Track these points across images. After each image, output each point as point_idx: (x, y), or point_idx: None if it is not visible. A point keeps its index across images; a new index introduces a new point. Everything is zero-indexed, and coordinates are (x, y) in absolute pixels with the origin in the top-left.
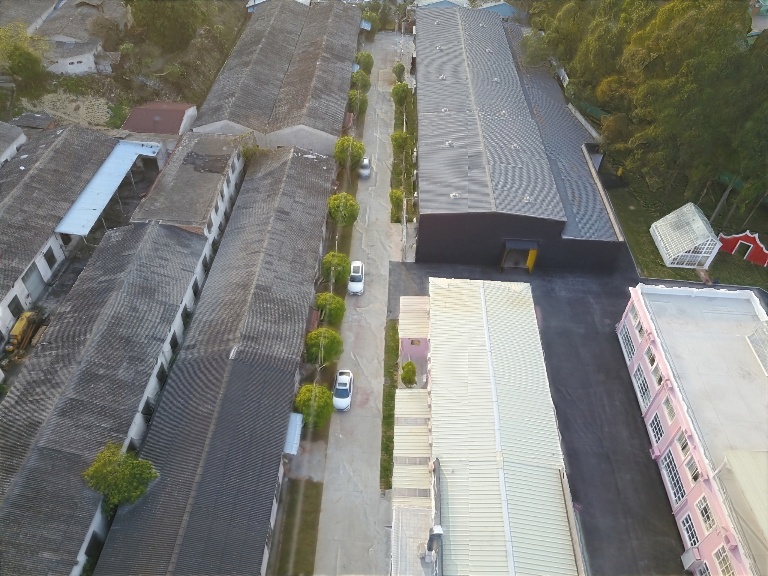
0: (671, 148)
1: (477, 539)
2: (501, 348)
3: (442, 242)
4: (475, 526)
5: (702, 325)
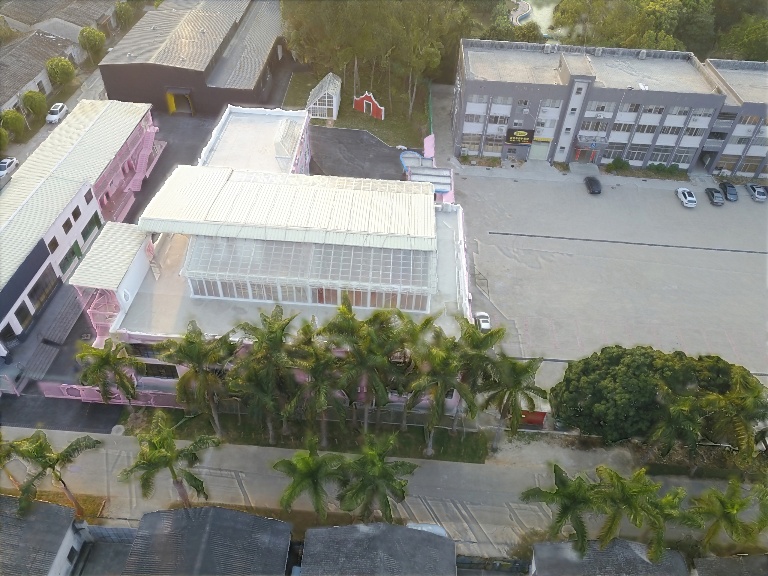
0: (303, 27)
1: (5, 206)
2: (97, 131)
3: (124, 90)
4: (8, 201)
5: (258, 128)
